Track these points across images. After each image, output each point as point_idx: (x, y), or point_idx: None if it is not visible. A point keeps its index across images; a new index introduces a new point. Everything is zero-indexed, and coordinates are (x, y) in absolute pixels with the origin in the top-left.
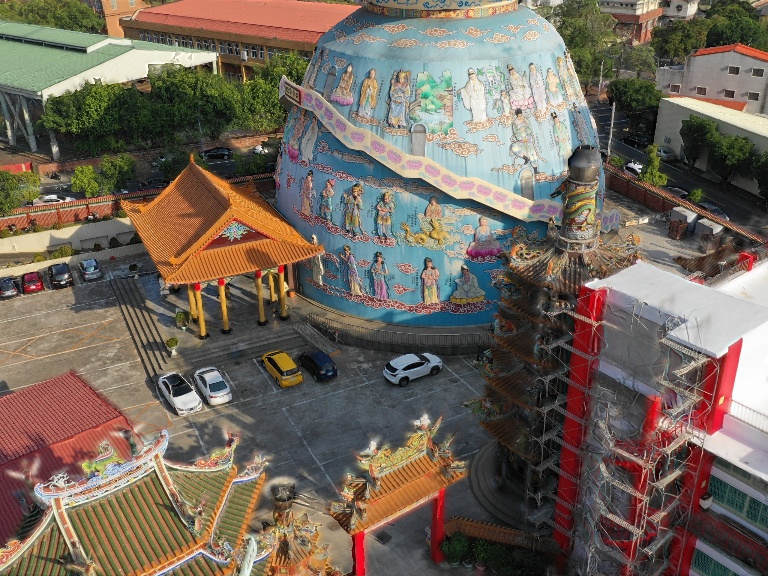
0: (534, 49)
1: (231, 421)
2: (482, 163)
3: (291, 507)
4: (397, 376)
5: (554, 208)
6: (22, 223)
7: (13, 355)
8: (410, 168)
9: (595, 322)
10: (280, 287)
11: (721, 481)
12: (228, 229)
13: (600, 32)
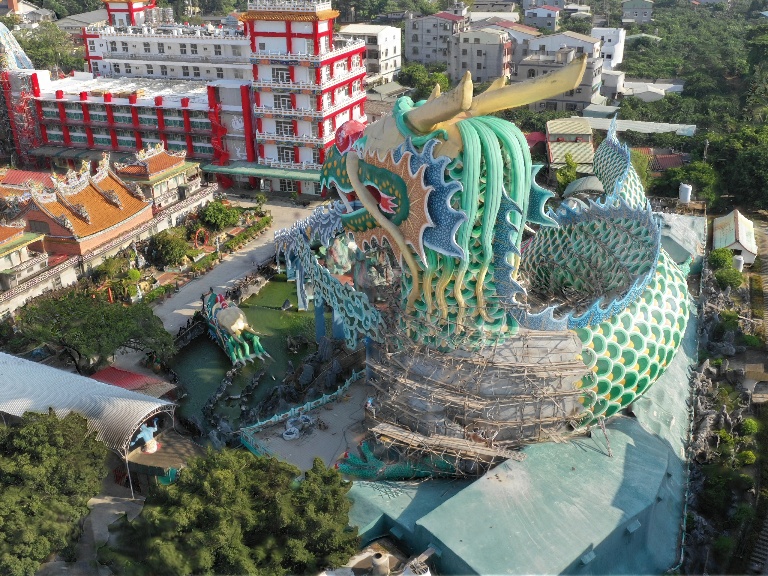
0: None
1: None
2: None
3: None
4: None
5: None
6: None
7: None
8: None
9: (6, 80)
10: None
11: (45, 111)
12: None
13: (56, 39)
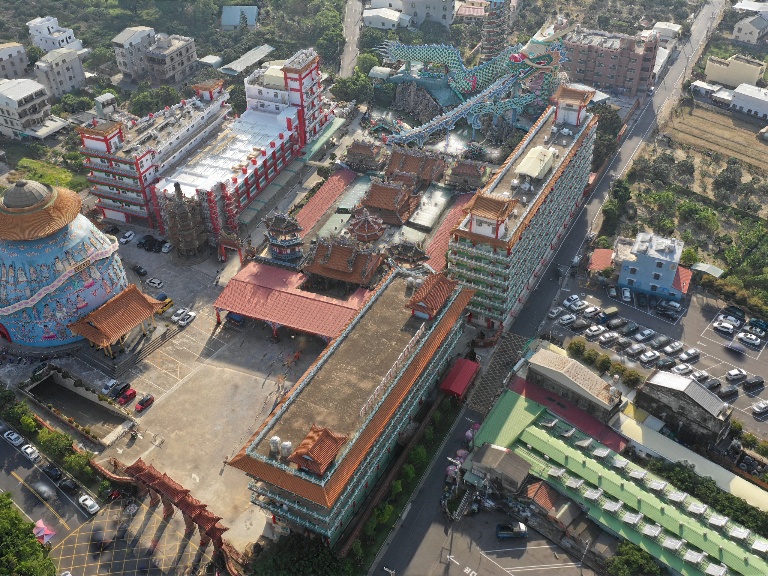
0: None
1: None
2: None
3: None
4: None
5: None
6: None
7: (181, 369)
8: None
9: None
10: None
11: None
12: None
13: None
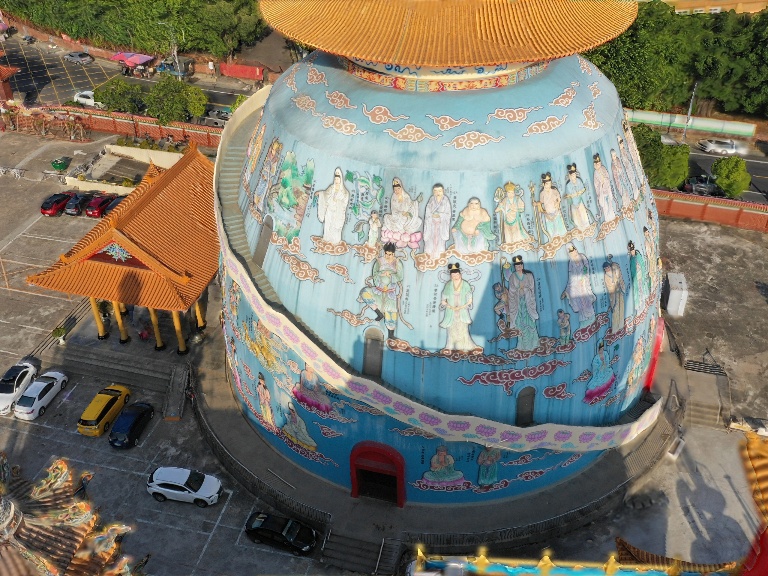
0: (457, 163)
1: (7, 442)
2: (318, 296)
3: None
4: (150, 488)
5: (384, 396)
6: (179, 136)
7: (1, 277)
8: (231, 268)
9: None
10: (174, 321)
11: None
12: (112, 248)
13: None
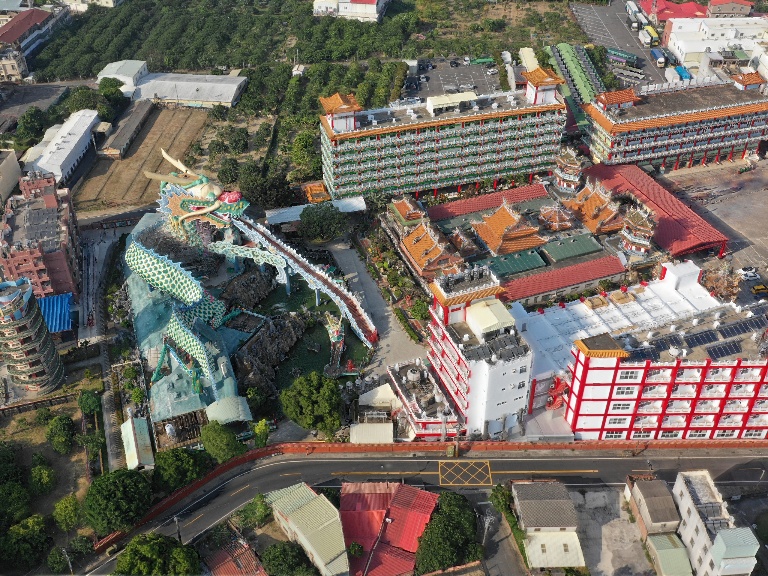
0: None
1: None
2: None
3: (666, 256)
4: None
5: None
6: None
7: None
8: None
9: None
10: None
11: None
12: None
13: None
